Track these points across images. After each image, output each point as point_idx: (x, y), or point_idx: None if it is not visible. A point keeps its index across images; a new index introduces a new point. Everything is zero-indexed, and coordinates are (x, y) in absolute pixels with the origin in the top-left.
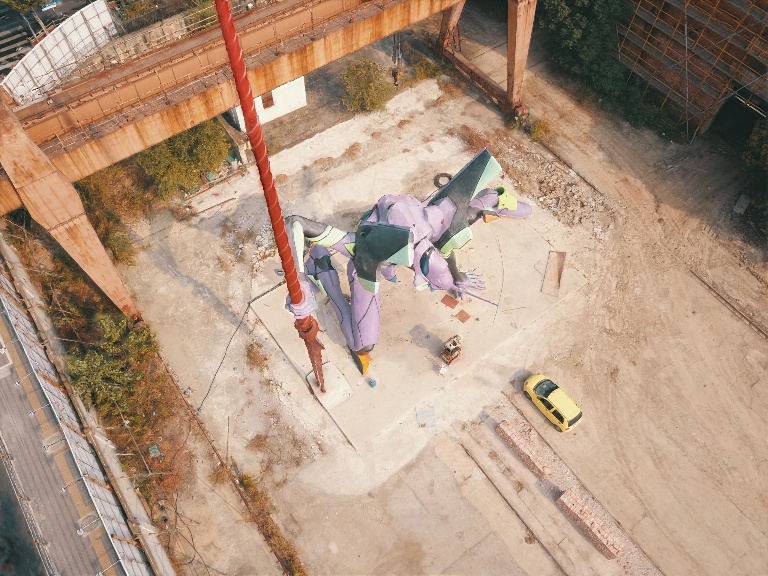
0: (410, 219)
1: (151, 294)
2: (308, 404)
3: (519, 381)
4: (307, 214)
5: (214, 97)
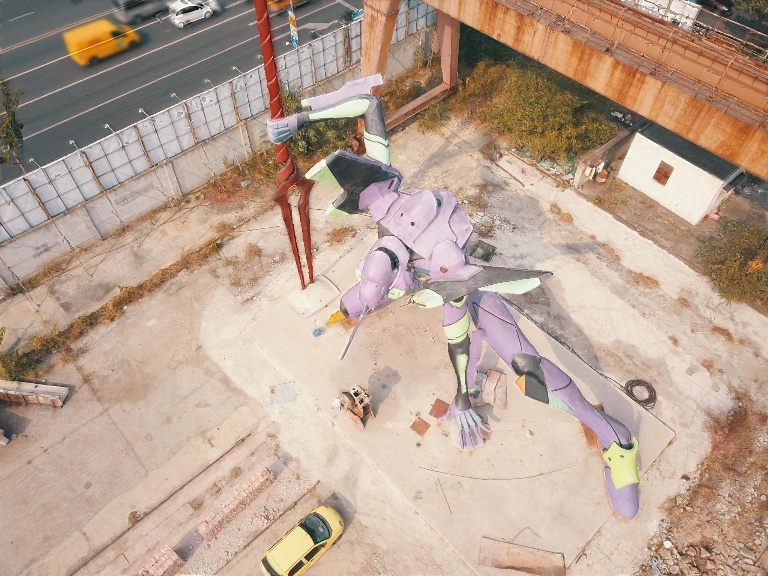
0: (417, 214)
1: (396, 151)
2: (294, 283)
3: (337, 505)
4: (526, 249)
5: (528, 30)
